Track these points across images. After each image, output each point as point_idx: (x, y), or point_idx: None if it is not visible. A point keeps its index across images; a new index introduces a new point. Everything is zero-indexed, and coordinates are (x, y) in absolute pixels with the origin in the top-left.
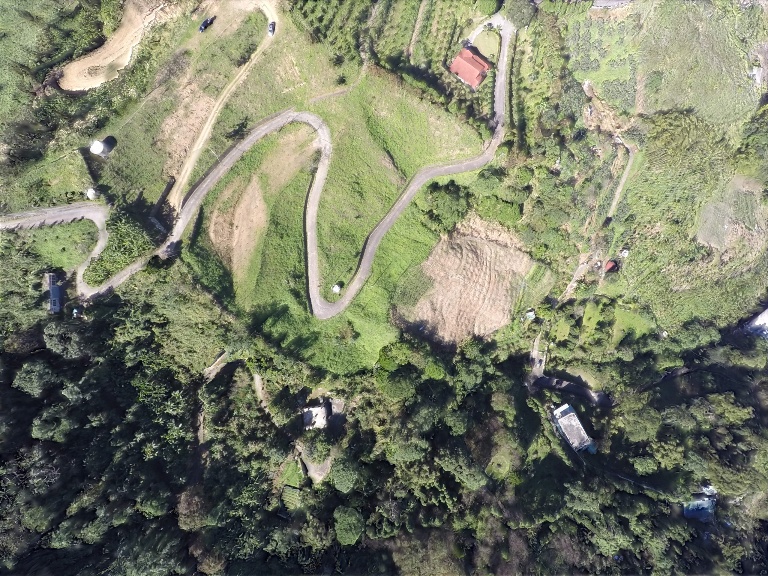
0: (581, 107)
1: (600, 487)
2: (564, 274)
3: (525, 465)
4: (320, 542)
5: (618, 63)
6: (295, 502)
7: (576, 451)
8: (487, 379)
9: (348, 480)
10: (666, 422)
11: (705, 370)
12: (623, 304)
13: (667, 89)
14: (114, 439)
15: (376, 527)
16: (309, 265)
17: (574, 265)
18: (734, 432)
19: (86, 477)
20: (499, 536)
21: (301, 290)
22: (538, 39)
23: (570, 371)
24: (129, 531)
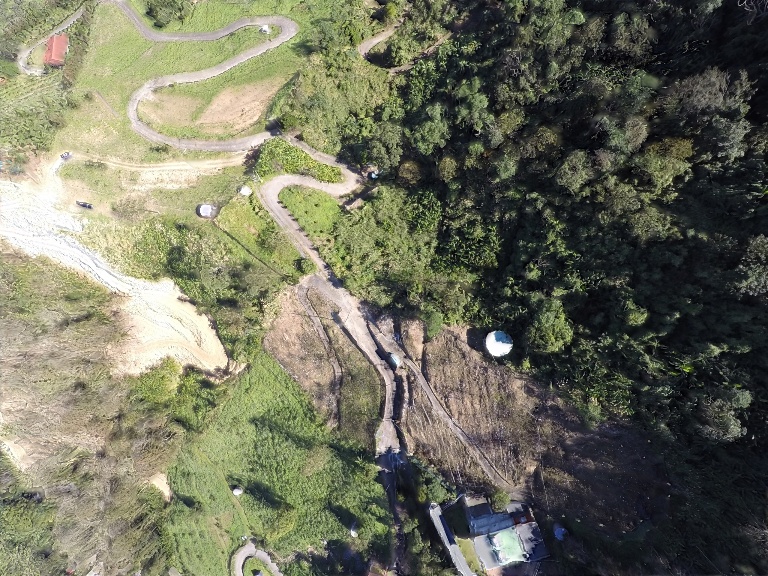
0: None
1: None
2: None
3: None
4: None
5: None
6: None
7: None
8: None
9: None
10: None
11: None
12: None
13: None
14: (472, 73)
15: None
16: None
17: None
18: None
19: None
20: None
21: None
22: None
23: None
24: None
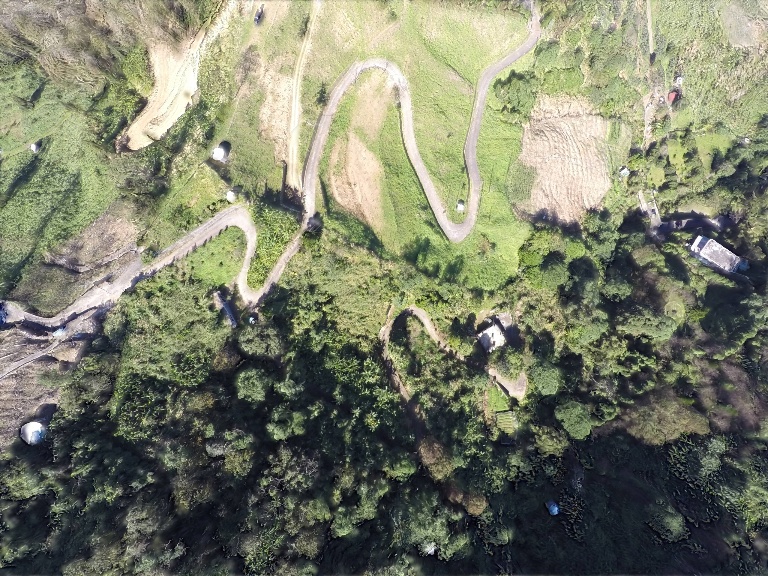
0: None
1: None
2: (636, 123)
3: (698, 300)
4: (560, 444)
5: None
6: (511, 425)
7: (732, 272)
8: (617, 245)
9: (553, 378)
10: None
11: None
12: (696, 131)
13: None
14: (338, 421)
15: (596, 415)
16: (427, 196)
17: (641, 111)
18: None
19: (333, 464)
20: (713, 371)
21: (431, 221)
22: None
23: (682, 210)
24: (392, 501)
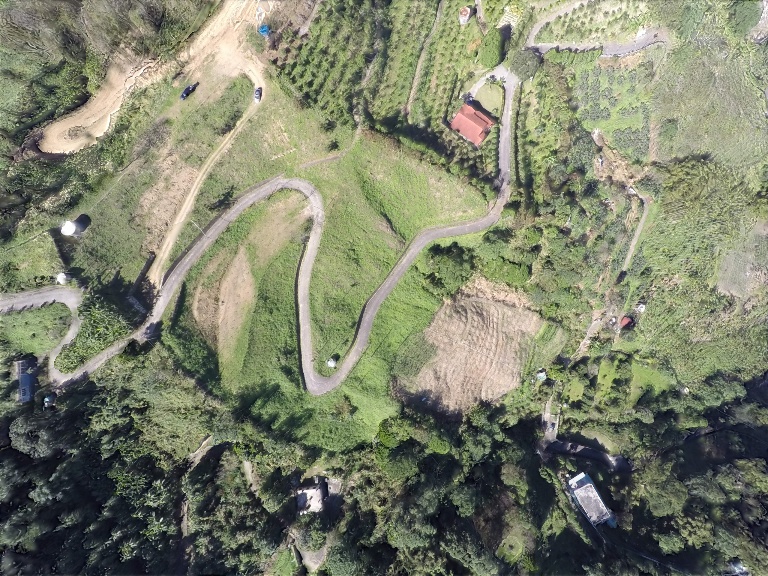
0: (591, 158)
1: (623, 571)
2: (576, 331)
3: (539, 547)
4: None
5: (630, 111)
6: None
7: (594, 526)
8: (496, 447)
9: (346, 572)
10: (692, 493)
11: (731, 430)
12: (640, 359)
13: (682, 135)
14: (87, 540)
15: None
16: (302, 338)
17: (587, 322)
18: (767, 504)
19: None
20: None
21: (293, 366)
22: (544, 90)
23: (585, 433)
24: None
